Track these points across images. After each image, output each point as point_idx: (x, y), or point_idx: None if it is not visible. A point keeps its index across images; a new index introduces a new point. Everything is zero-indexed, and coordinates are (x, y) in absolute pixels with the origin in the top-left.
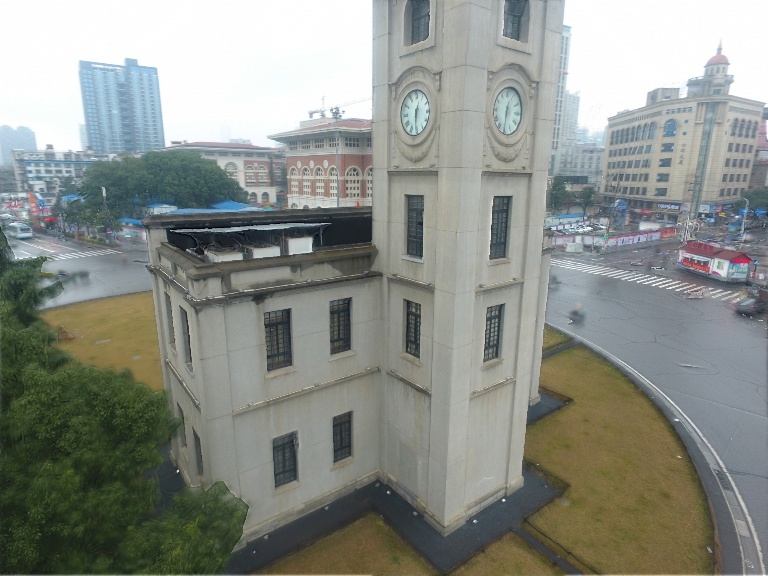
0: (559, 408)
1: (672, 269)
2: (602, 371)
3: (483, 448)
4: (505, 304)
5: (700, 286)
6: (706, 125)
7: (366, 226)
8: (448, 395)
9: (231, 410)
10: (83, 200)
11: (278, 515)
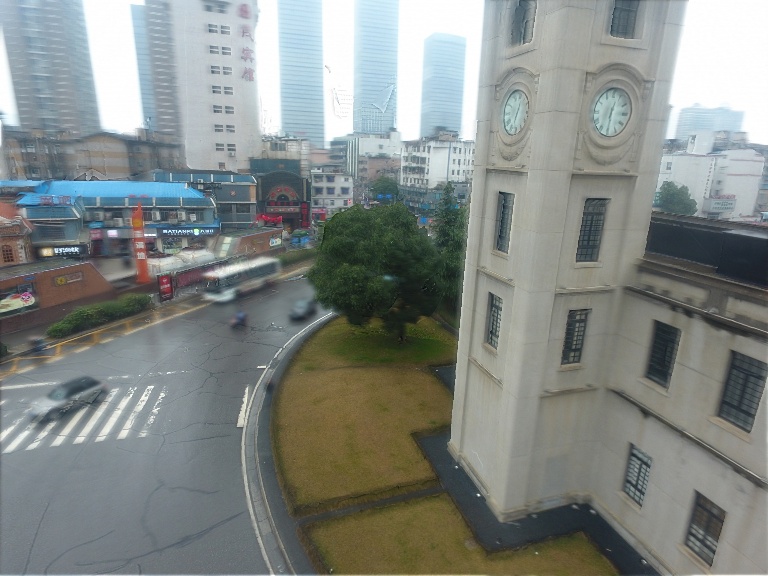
0: None
1: None
2: None
3: (478, 422)
4: (503, 300)
5: None
6: None
7: None
8: None
9: None
10: None
11: None
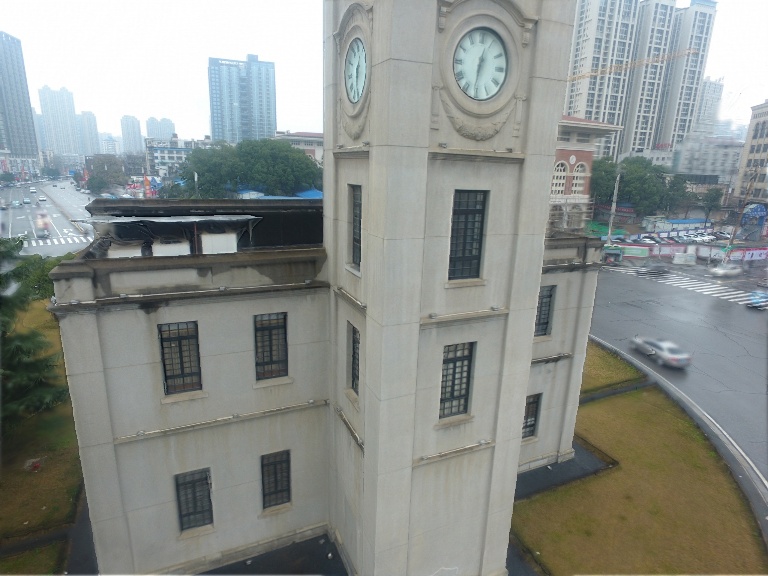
0: (596, 472)
1: None
2: (674, 427)
3: (440, 530)
4: (477, 342)
5: None
6: None
7: None
8: (376, 460)
9: (112, 438)
10: (182, 184)
11: (185, 563)
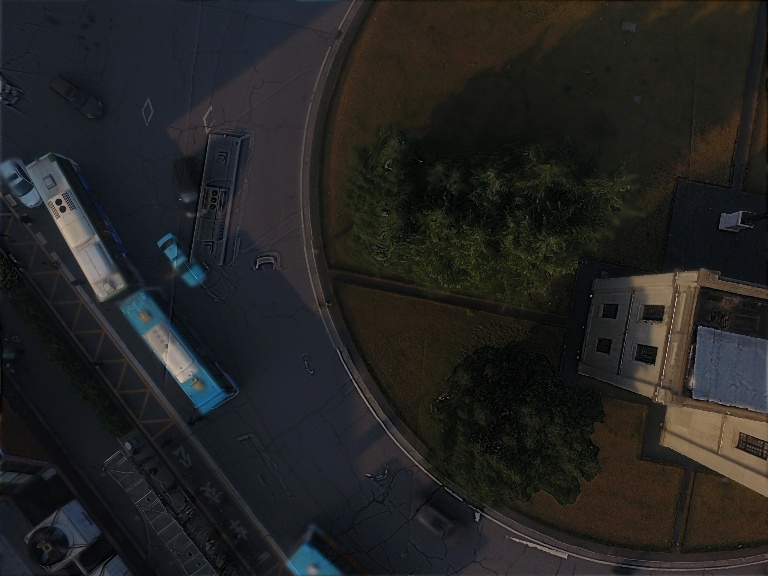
0: None
1: None
2: None
3: None
4: None
5: None
6: None
7: None
8: (719, 471)
9: None
10: None
11: None
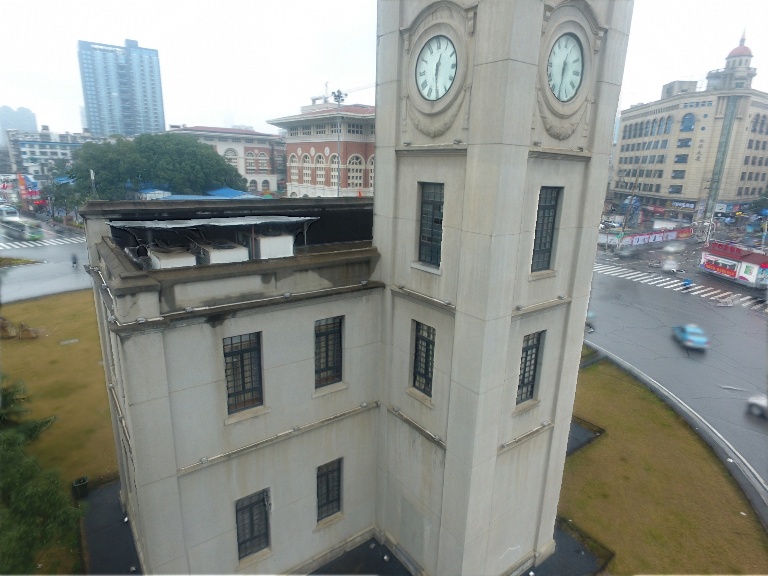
0: (589, 441)
1: (693, 272)
2: (634, 393)
3: (509, 513)
4: (546, 330)
5: (726, 292)
6: (726, 120)
7: (366, 220)
8: (470, 453)
9: (175, 470)
10: (72, 183)
11: None
